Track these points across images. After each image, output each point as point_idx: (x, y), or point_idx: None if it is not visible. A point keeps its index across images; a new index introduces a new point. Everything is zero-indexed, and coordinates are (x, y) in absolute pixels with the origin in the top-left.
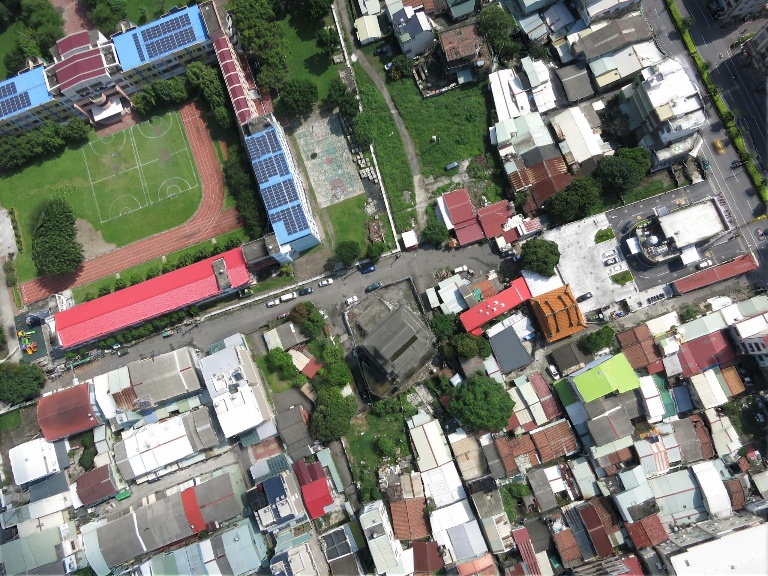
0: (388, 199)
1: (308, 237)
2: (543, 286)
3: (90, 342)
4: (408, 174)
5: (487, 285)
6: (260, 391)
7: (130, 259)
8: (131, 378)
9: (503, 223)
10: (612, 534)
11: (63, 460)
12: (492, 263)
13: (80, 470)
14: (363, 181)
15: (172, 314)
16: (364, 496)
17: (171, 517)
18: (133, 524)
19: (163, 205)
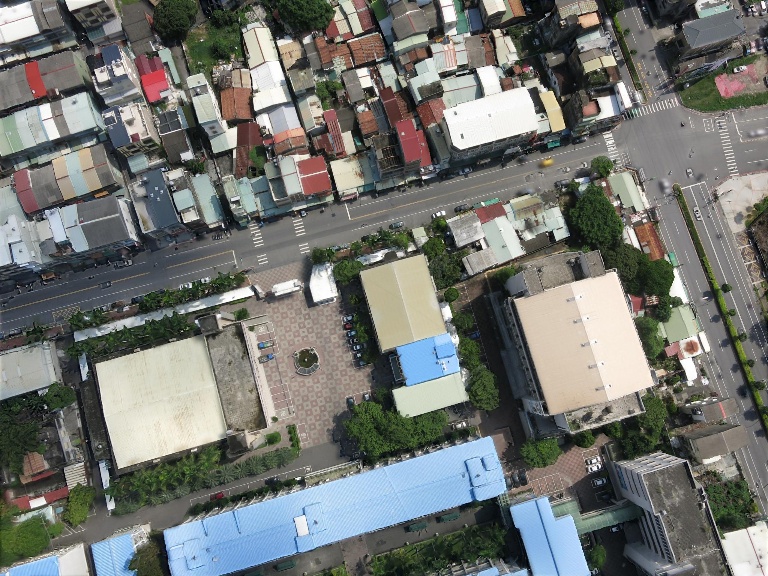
0: None
1: None
2: None
3: None
4: None
5: None
6: None
7: None
8: None
9: None
10: None
11: None
12: None
13: None
14: None
15: None
16: None
17: (13, 82)
18: None
19: None
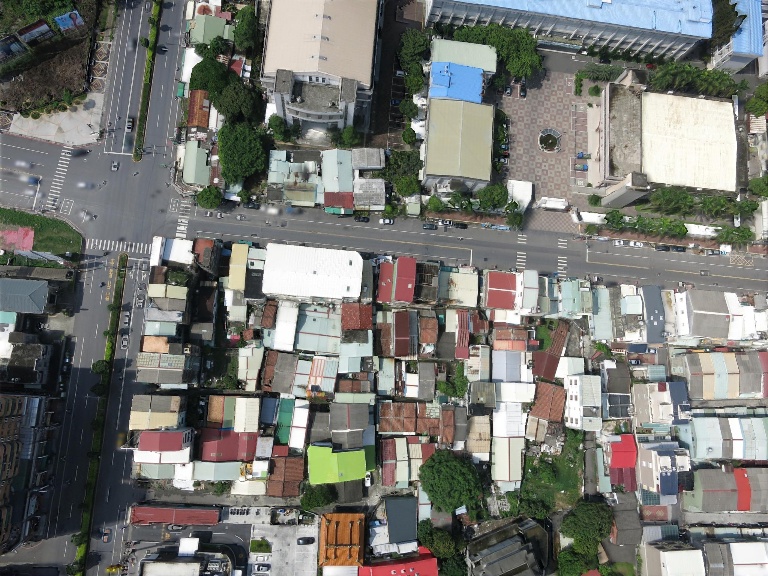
0: None
1: None
2: (344, 574)
3: None
4: None
5: None
6: (649, 575)
7: None
8: None
9: None
10: (384, 322)
11: None
12: None
13: None
14: None
15: None
16: None
17: (764, 492)
18: None
19: None
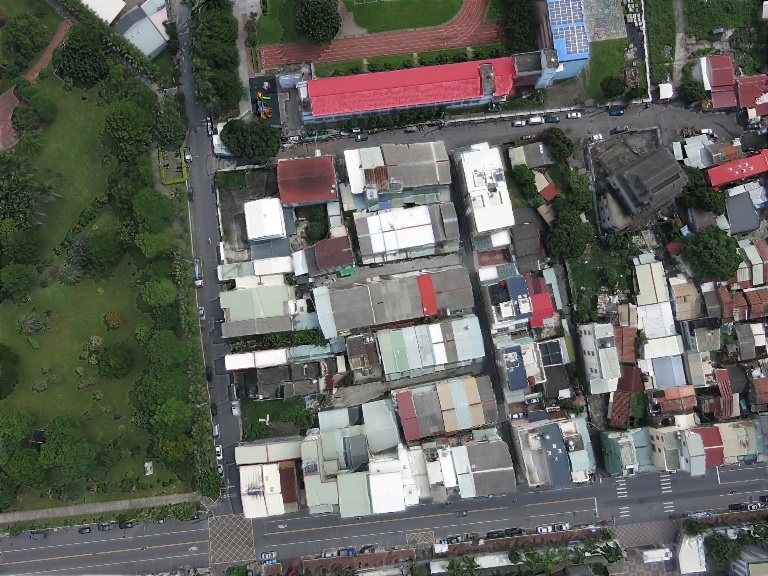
0: (648, 49)
1: (583, 61)
2: None
3: (329, 120)
4: (672, 29)
5: (732, 150)
6: None
7: (380, 48)
8: (385, 158)
9: (758, 96)
10: None
11: (290, 227)
12: (735, 132)
13: (301, 242)
14: (627, 26)
15: (424, 109)
16: (585, 316)
17: (406, 296)
18: (368, 295)
19: (422, 1)
